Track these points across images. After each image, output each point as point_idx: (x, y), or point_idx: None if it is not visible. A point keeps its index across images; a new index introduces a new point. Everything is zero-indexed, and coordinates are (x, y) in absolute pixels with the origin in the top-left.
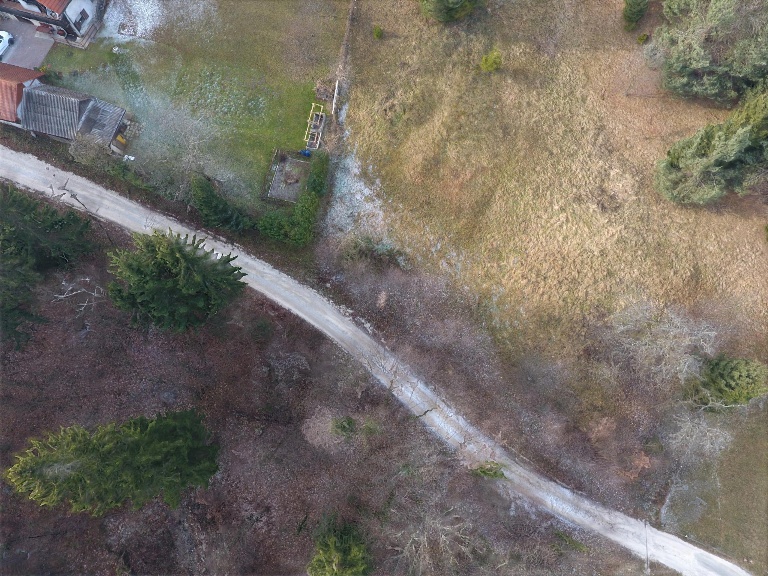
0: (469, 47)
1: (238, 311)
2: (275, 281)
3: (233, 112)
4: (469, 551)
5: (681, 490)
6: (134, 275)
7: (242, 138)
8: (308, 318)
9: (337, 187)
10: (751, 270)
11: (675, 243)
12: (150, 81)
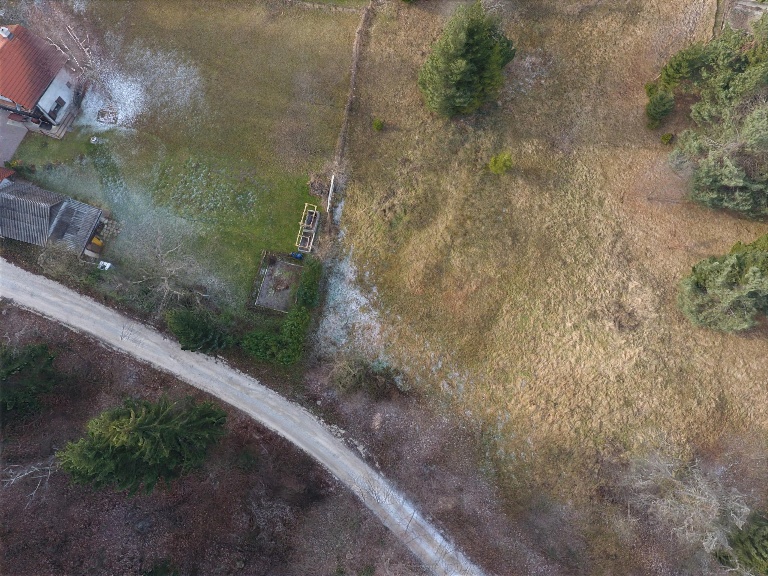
0: (477, 144)
1: (214, 467)
2: (261, 398)
3: (220, 208)
4: None
5: None
6: (91, 463)
7: (229, 237)
8: (296, 440)
9: (330, 294)
10: None
11: (699, 369)
12: (130, 174)
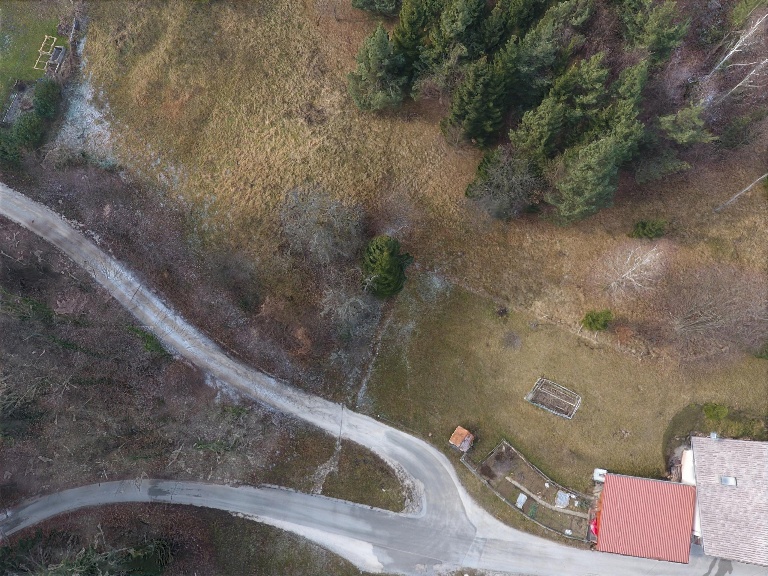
0: None
1: None
2: (8, 198)
3: None
4: (181, 439)
5: (376, 375)
6: None
7: None
8: (37, 231)
9: (70, 112)
10: (438, 171)
11: (371, 150)
12: None
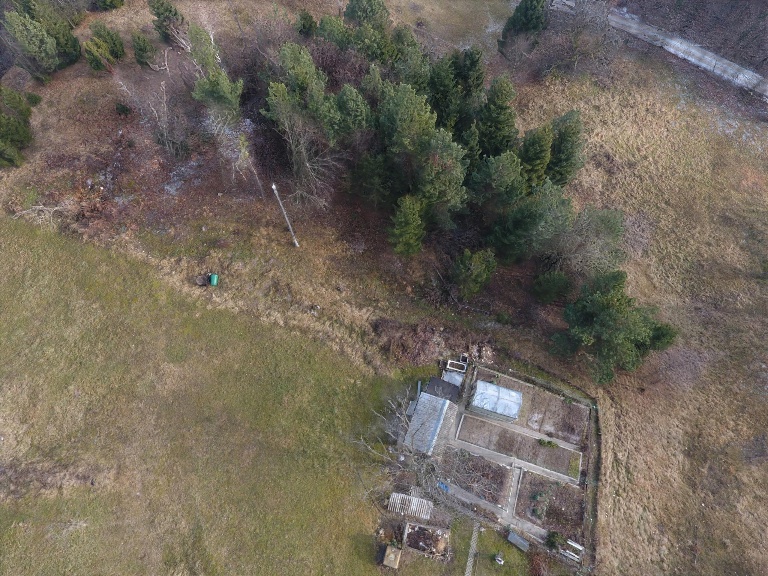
0: None
1: None
2: None
3: None
4: (642, 0)
5: None
6: None
7: None
8: None
9: None
10: None
11: None
12: None
